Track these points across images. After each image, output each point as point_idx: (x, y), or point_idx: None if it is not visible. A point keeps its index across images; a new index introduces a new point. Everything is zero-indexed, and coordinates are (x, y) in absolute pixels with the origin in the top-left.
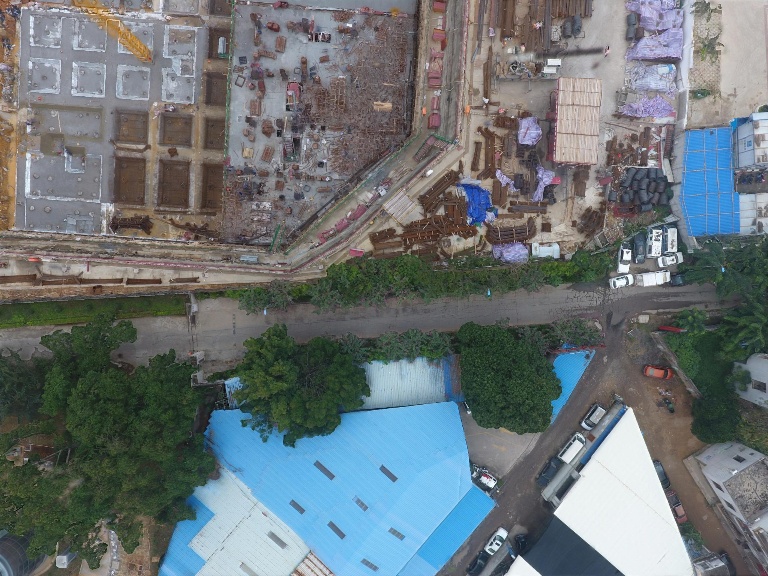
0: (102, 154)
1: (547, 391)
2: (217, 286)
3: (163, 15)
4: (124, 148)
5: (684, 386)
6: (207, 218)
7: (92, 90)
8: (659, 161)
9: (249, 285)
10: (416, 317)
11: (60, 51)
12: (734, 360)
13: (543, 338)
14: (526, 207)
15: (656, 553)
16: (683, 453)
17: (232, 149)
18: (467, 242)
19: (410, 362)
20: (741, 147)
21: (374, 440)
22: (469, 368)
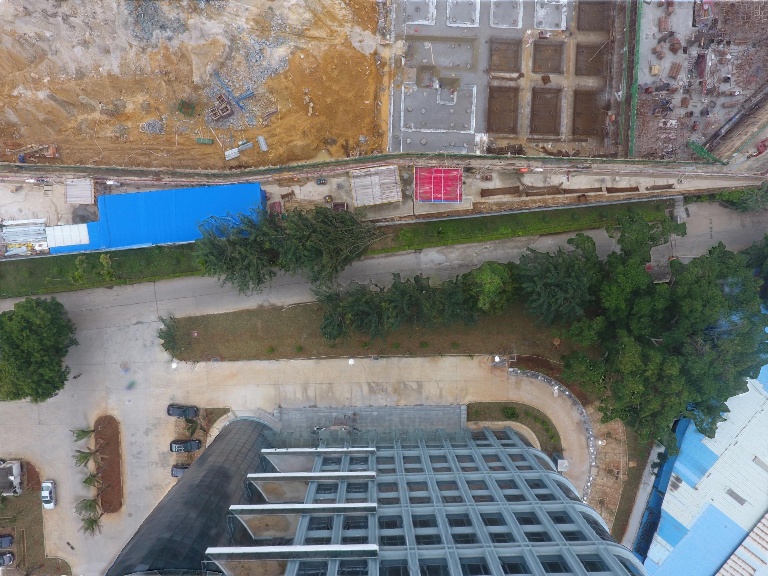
0: (476, 84)
1: None
2: (693, 192)
3: None
4: (498, 77)
5: None
6: (578, 145)
7: (464, 20)
8: None
9: (724, 189)
10: None
11: None
12: None
13: None
14: None
15: None
16: None
17: (639, 67)
18: None
19: None
20: None
21: None
22: None
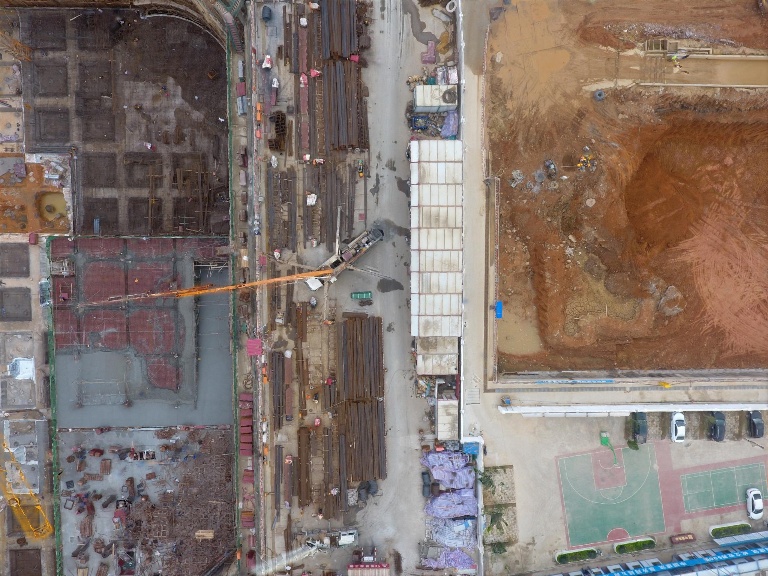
0: None
1: None
2: None
3: (1, 411)
4: None
5: None
6: None
7: None
8: None
9: None
10: None
11: None
12: None
13: None
14: None
15: None
16: None
17: (67, 569)
18: None
19: None
20: None
21: None
22: None
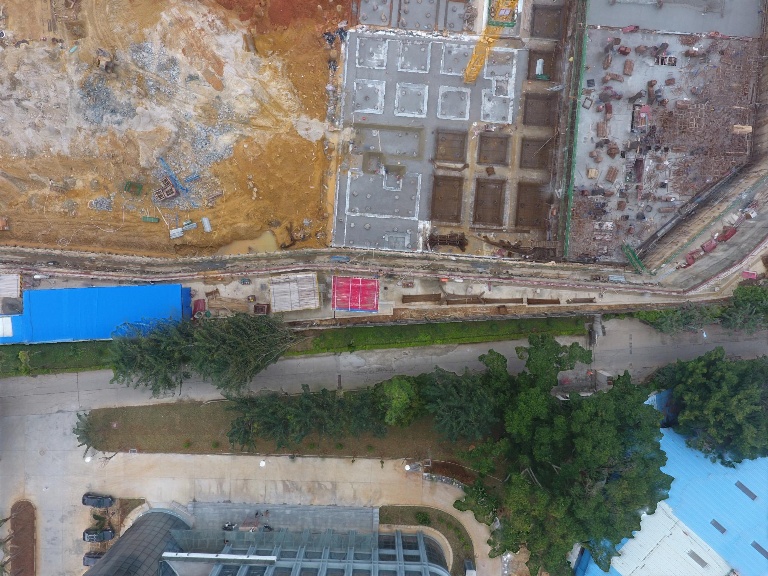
0: (421, 173)
1: None
2: (614, 306)
3: (485, 37)
4: (443, 167)
5: None
6: (520, 236)
7: (412, 110)
8: None
9: (645, 306)
10: None
11: (386, 72)
12: None
13: None
14: None
15: None
16: None
17: (577, 170)
18: None
19: None
20: None
21: None
22: None
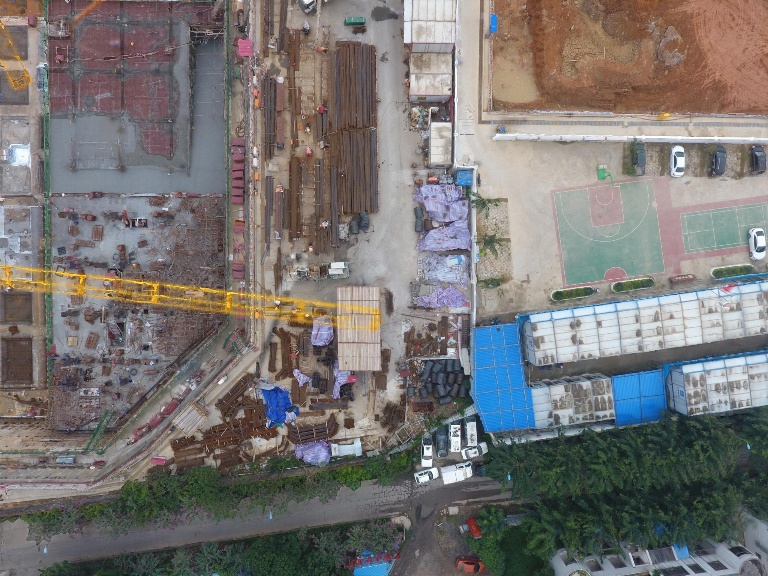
0: None
1: None
2: (20, 504)
3: None
4: None
5: None
6: None
7: None
8: (457, 351)
9: (52, 501)
10: (221, 522)
11: None
12: None
13: (339, 548)
14: (326, 404)
15: None
16: None
17: (57, 338)
18: (269, 443)
19: None
20: (528, 343)
21: None
22: None
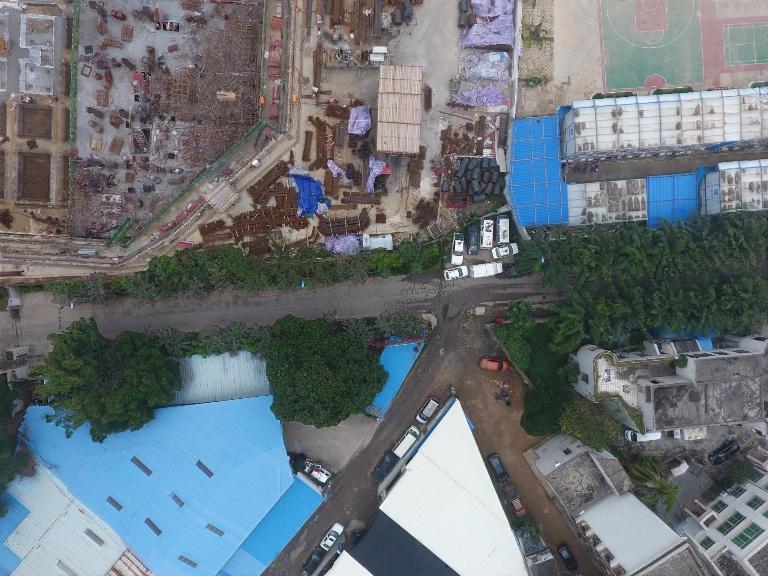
0: None
1: (333, 384)
2: (42, 280)
3: (19, 4)
4: None
5: (522, 378)
6: None
7: None
8: (493, 150)
9: (75, 278)
10: (247, 310)
11: None
12: (565, 352)
13: (367, 331)
14: (359, 198)
15: (486, 547)
16: (523, 446)
17: (80, 140)
18: (299, 234)
19: (230, 356)
20: (567, 136)
21: (191, 435)
22: (268, 361)
